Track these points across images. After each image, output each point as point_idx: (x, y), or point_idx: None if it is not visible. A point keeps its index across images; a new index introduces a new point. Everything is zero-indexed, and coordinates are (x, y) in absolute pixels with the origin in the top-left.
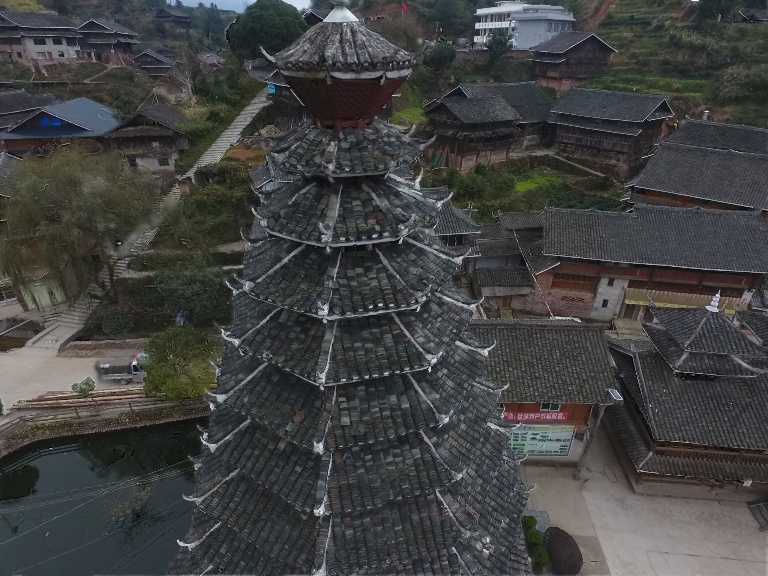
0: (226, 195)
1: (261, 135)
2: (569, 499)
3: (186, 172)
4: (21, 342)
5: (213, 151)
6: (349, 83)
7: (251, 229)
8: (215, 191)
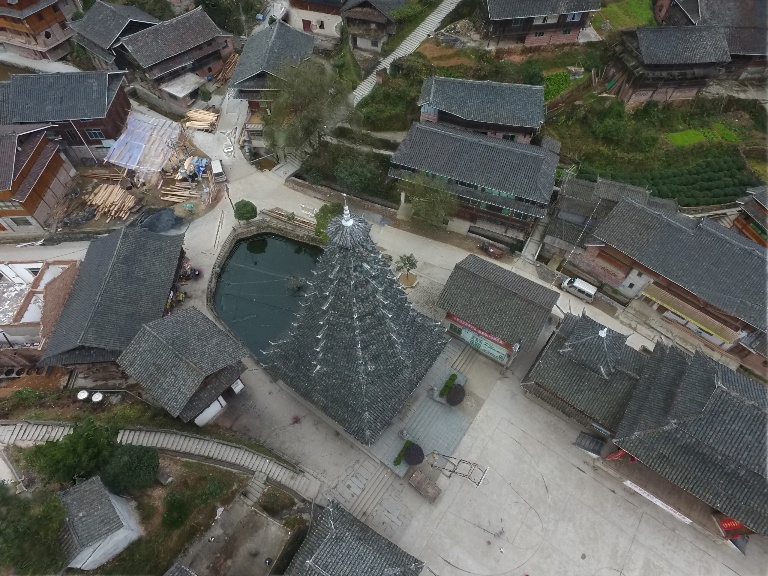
0: (405, 92)
1: (455, 29)
2: (488, 380)
3: (388, 56)
4: (270, 163)
5: (414, 37)
6: None
7: None
8: (399, 86)
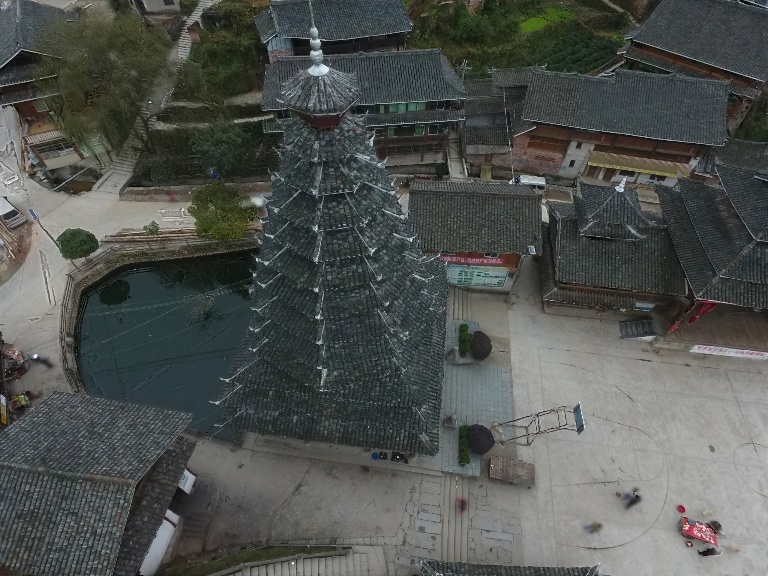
0: (234, 43)
1: None
2: (497, 315)
3: (192, 12)
4: (85, 185)
5: None
6: (323, 116)
7: (263, 91)
8: (224, 39)
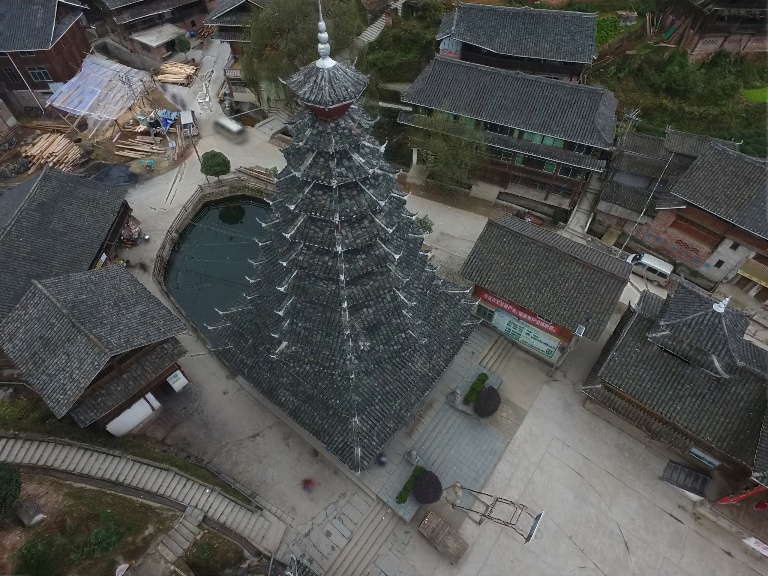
0: (420, 35)
1: None
2: (530, 383)
3: None
4: (255, 122)
5: None
6: (312, 106)
7: None
8: (412, 28)
